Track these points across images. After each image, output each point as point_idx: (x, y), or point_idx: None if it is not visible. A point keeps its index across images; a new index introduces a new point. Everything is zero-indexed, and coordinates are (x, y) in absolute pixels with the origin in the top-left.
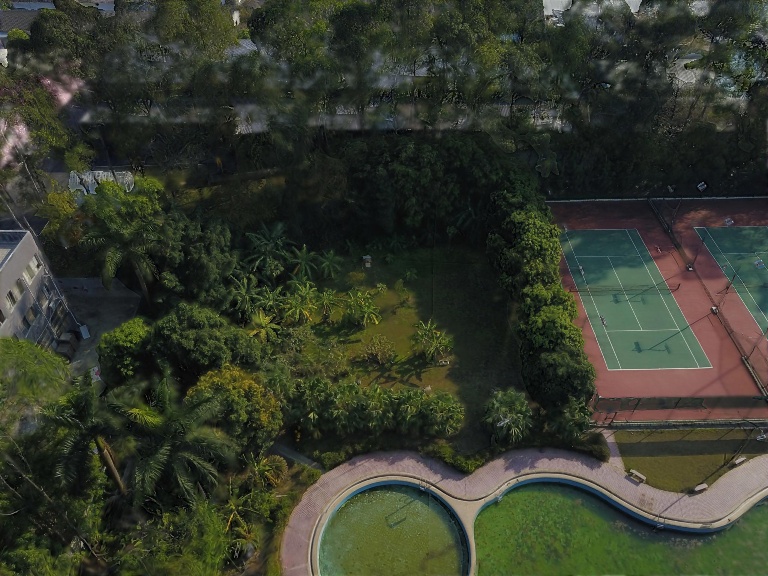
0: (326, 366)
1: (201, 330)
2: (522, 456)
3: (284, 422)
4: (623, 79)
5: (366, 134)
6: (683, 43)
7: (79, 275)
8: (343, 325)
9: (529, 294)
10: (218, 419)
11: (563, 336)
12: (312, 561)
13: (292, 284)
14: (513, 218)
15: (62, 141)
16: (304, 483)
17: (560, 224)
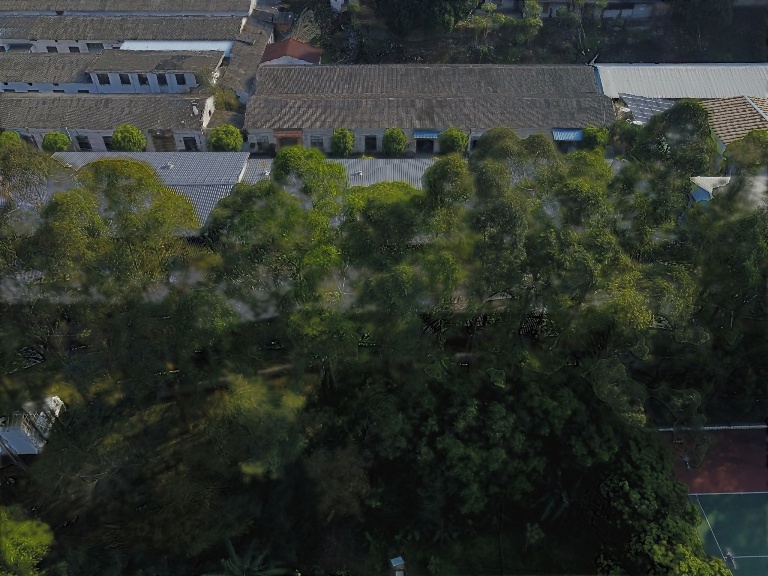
0: None
1: None
2: None
3: None
4: None
5: (396, 365)
6: None
7: None
8: None
9: None
10: None
11: None
12: None
13: None
14: (649, 550)
15: None
16: None
17: (686, 480)
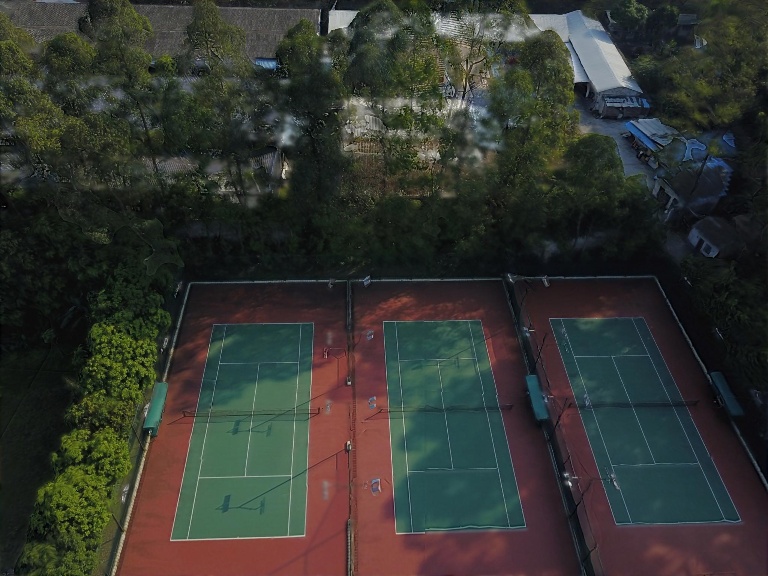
0: None
1: None
2: None
3: None
4: (282, 145)
5: None
6: (335, 107)
7: None
8: None
9: None
10: None
11: None
12: None
13: None
14: None
15: None
16: None
17: (225, 315)
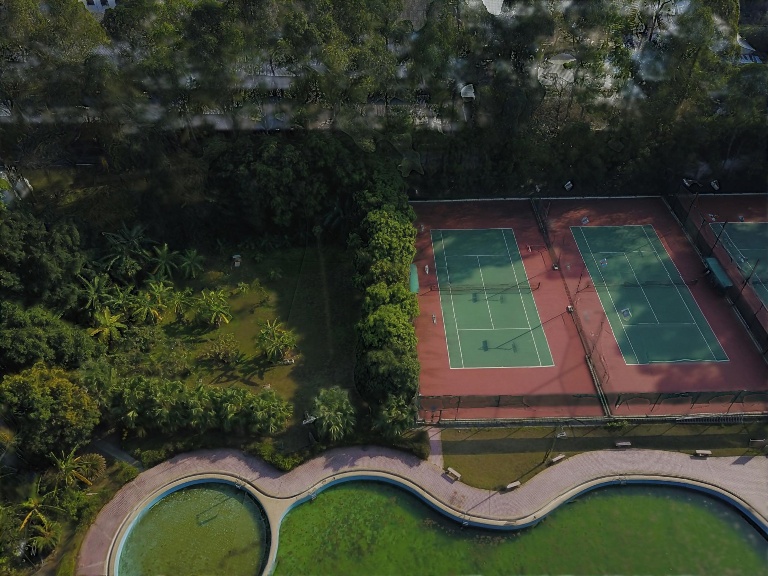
0: (165, 365)
1: (22, 329)
2: (344, 454)
3: (104, 420)
4: (493, 79)
5: (237, 134)
6: (546, 43)
7: None
8: (197, 324)
9: (370, 293)
10: (19, 417)
11: (391, 334)
12: (110, 559)
13: None
14: (368, 217)
15: None
16: (118, 481)
17: (438, 224)
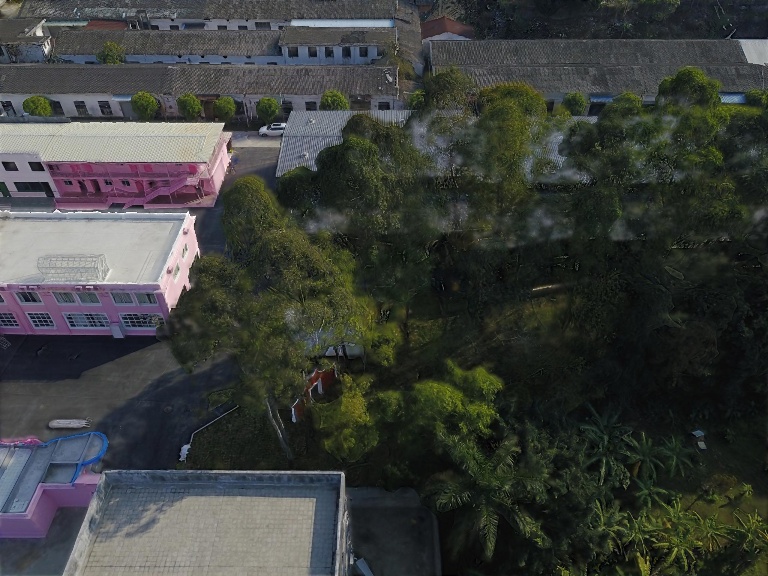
0: None
1: None
2: None
3: None
4: None
5: (693, 269)
6: None
7: (326, 468)
8: (725, 559)
9: None
10: None
11: None
12: None
13: (642, 496)
14: None
15: (365, 324)
16: None
17: None
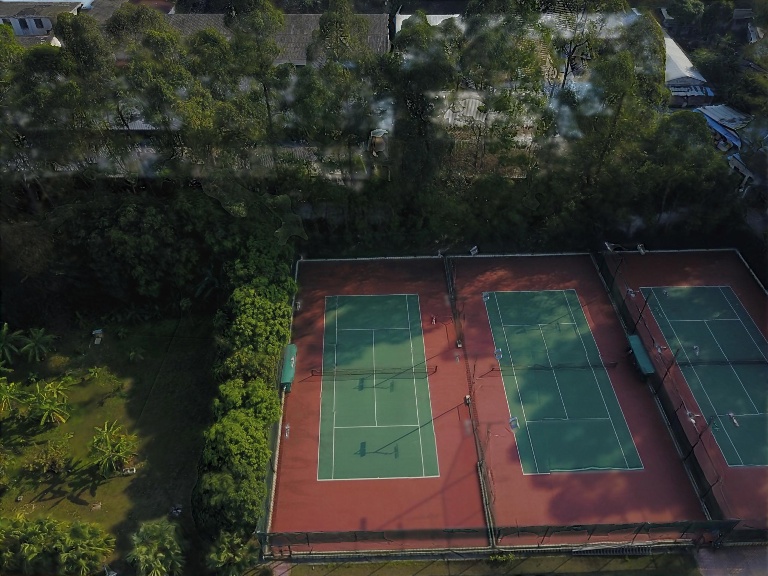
0: None
1: None
2: None
3: None
4: (392, 128)
5: None
6: (446, 90)
7: None
8: (32, 422)
9: None
10: None
11: (231, 453)
12: None
13: None
14: (234, 295)
15: None
16: None
17: (335, 288)
